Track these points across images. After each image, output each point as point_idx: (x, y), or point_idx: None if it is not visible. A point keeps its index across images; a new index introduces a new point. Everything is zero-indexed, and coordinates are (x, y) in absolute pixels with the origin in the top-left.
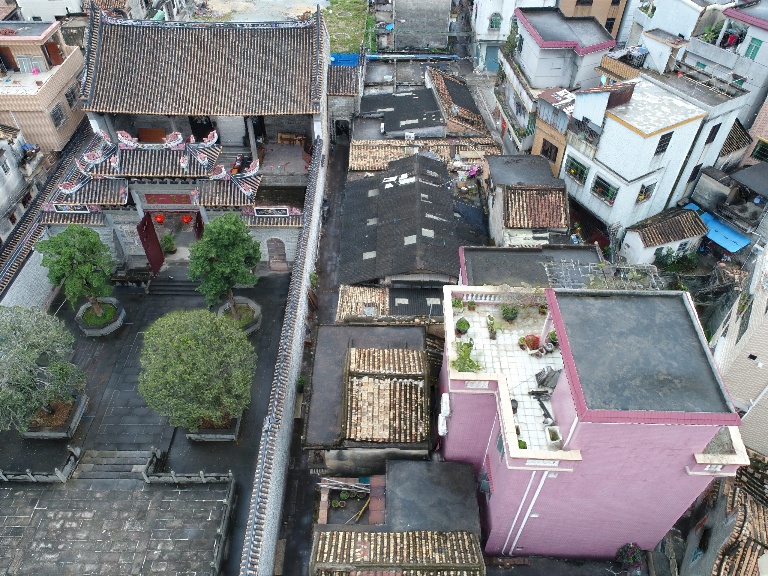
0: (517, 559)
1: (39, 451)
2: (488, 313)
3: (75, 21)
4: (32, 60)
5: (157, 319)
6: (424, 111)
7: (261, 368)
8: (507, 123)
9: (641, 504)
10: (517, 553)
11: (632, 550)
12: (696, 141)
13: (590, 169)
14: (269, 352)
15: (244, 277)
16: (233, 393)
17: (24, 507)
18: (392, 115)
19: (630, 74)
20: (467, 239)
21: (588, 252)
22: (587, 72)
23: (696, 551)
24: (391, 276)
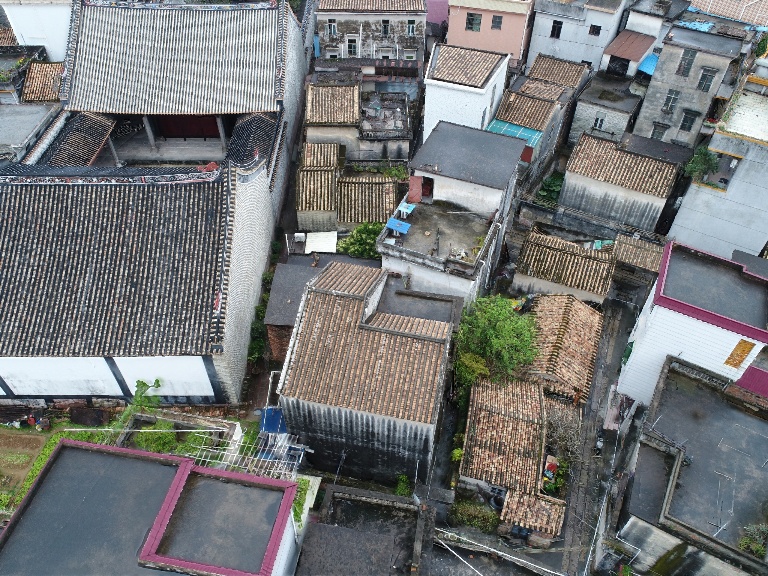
0: None
1: None
2: None
3: None
4: None
5: None
6: None
7: (301, 19)
8: None
9: None
10: None
11: (443, 21)
12: None
13: None
14: None
15: None
16: None
17: None
18: None
19: None
20: None
21: None
22: None
23: None
24: None
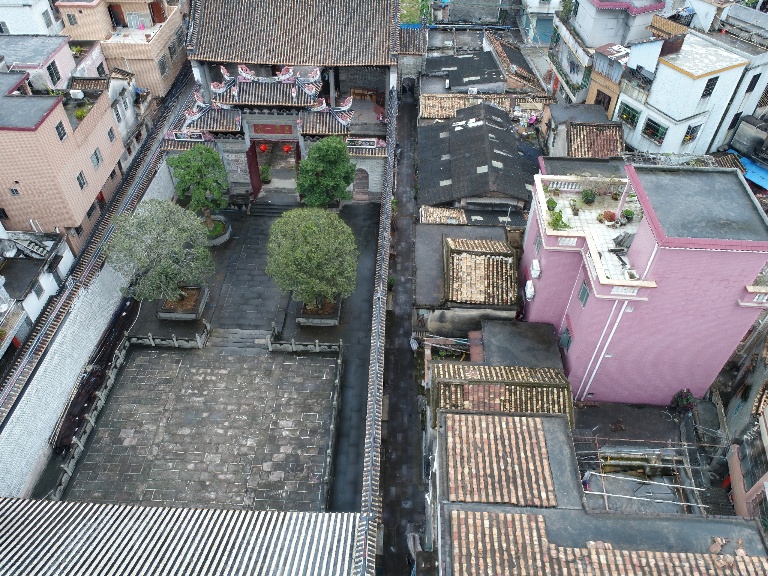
0: (589, 402)
1: (173, 329)
2: (570, 198)
3: None
4: (139, 17)
5: (259, 234)
6: (485, 70)
7: None
8: (561, 81)
9: (698, 343)
10: (588, 400)
11: (686, 394)
12: (738, 88)
13: (641, 113)
14: None
15: (343, 192)
16: (346, 274)
17: (170, 365)
18: (456, 73)
19: (679, 31)
20: (530, 172)
21: None
22: (638, 32)
23: (737, 408)
24: (466, 198)
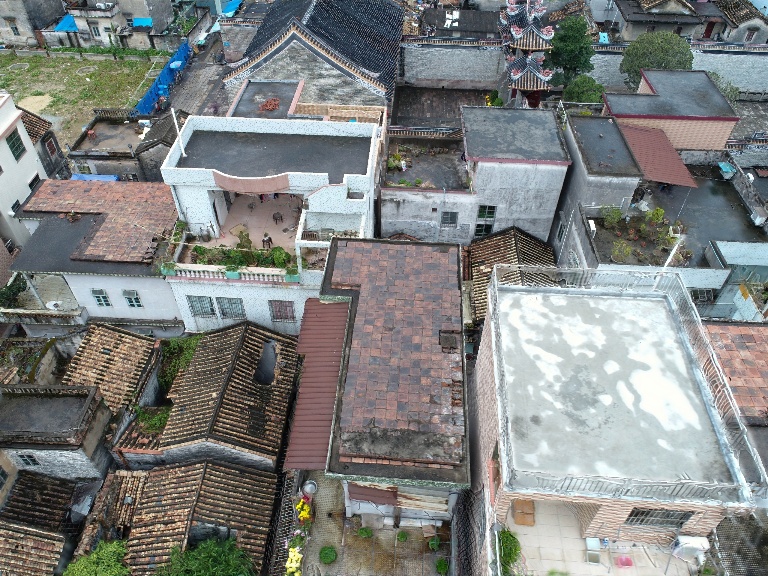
0: None
1: None
2: None
3: (98, 147)
4: None
5: None
6: None
7: None
8: None
9: None
10: None
11: None
12: None
13: None
14: None
15: None
16: None
17: None
18: None
19: None
20: None
21: None
22: None
23: None
24: None
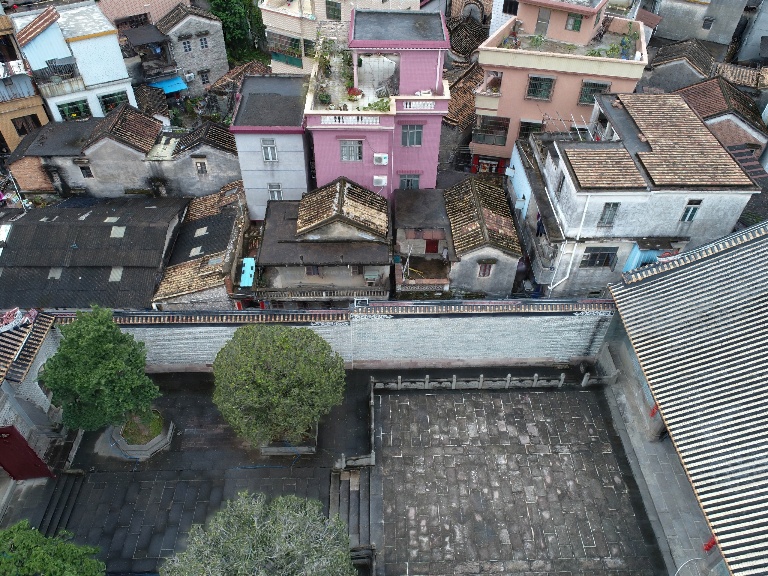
0: None
1: None
2: None
3: None
4: None
5: (112, 538)
6: None
7: None
8: None
9: None
10: None
11: None
12: None
13: (88, 99)
14: (204, 396)
15: None
16: None
17: None
18: None
19: None
20: (120, 206)
21: (249, 80)
22: None
23: None
24: None
